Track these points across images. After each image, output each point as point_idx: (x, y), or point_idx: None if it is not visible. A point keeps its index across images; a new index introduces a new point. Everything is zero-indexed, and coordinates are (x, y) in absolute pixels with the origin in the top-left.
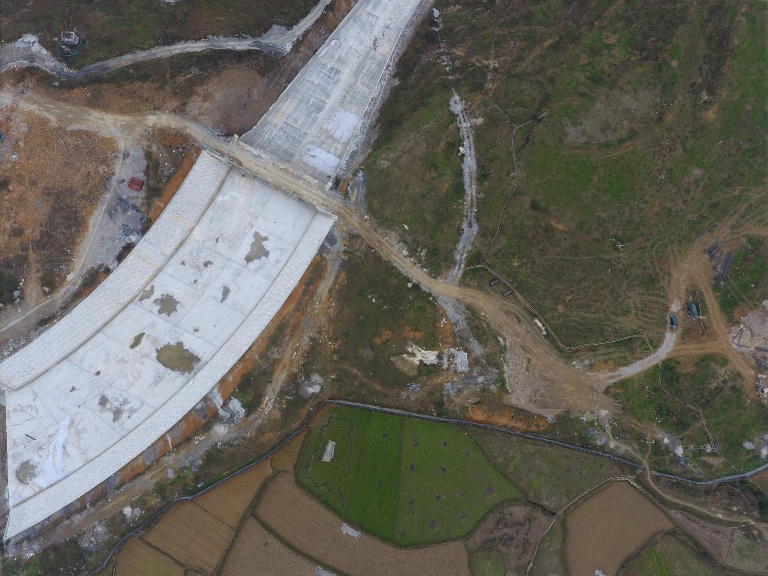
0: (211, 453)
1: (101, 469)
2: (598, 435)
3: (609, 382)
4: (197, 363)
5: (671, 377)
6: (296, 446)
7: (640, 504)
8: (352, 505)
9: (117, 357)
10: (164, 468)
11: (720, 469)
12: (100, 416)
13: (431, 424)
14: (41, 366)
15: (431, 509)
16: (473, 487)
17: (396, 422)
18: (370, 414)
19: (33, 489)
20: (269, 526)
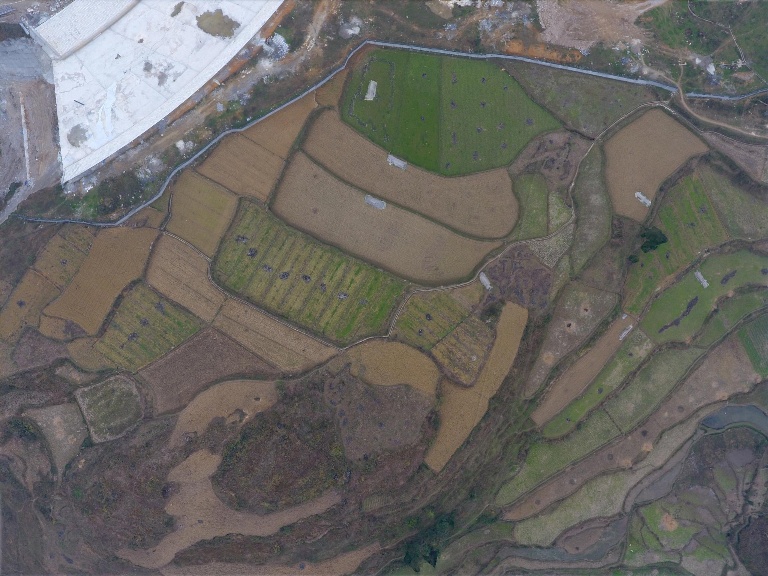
0: (258, 88)
1: (151, 119)
2: (631, 63)
3: (639, 12)
4: (237, 28)
5: (699, 0)
6: (339, 83)
7: (675, 130)
8: (396, 140)
9: (159, 25)
10: (213, 103)
11: (751, 84)
12: (146, 81)
13: (468, 62)
14: (86, 31)
15: (473, 141)
16: (512, 119)
17: (434, 61)
18: (409, 55)
19: (85, 151)
20: (317, 160)
